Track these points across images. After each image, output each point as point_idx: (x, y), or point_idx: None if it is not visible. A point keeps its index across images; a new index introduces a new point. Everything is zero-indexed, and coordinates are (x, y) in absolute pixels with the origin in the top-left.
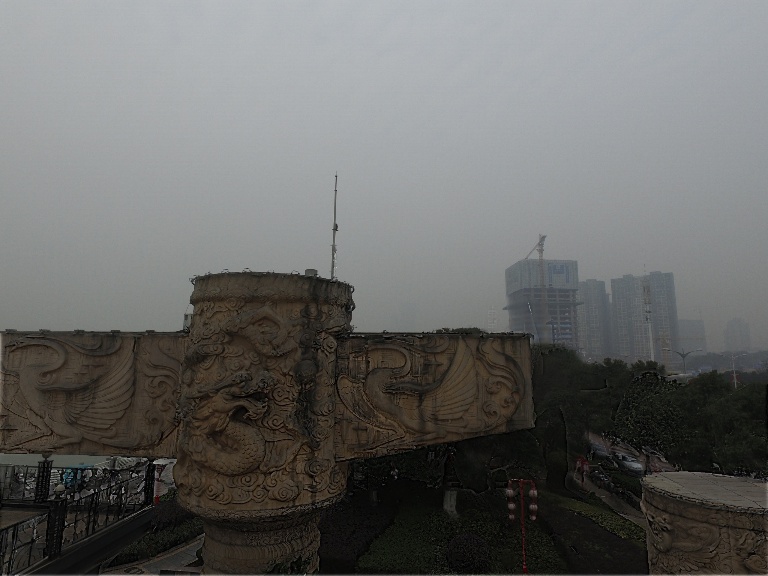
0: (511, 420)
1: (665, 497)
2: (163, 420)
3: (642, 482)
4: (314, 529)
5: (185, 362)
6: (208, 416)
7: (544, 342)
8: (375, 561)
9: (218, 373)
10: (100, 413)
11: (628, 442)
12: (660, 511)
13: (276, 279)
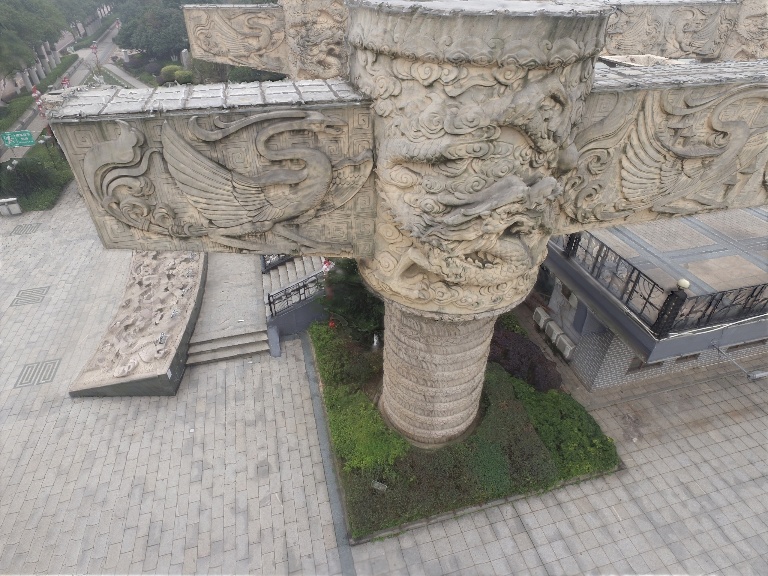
0: None
1: None
2: None
3: None
4: None
5: None
6: None
7: None
8: None
9: None
10: None
11: None
12: None
13: None
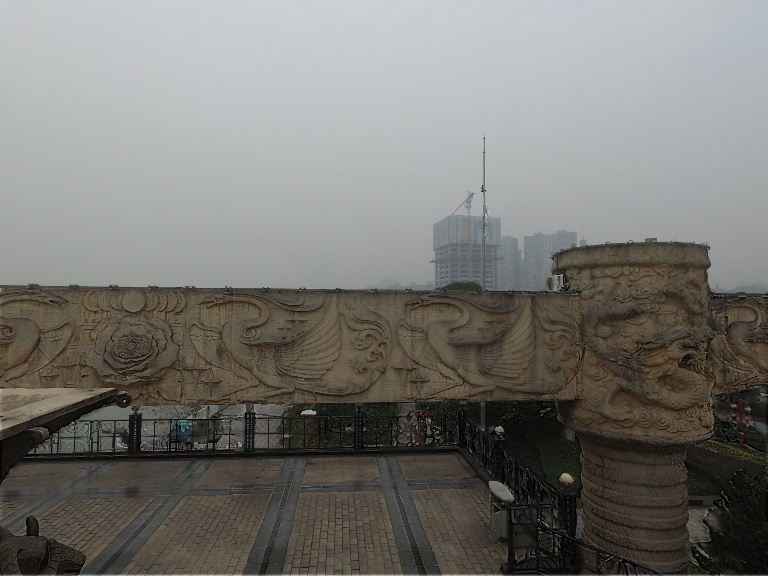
0: None
1: None
2: (564, 368)
3: None
4: None
5: (598, 318)
6: (663, 363)
7: None
8: None
9: (656, 328)
10: (508, 364)
11: None
12: None
13: (693, 248)
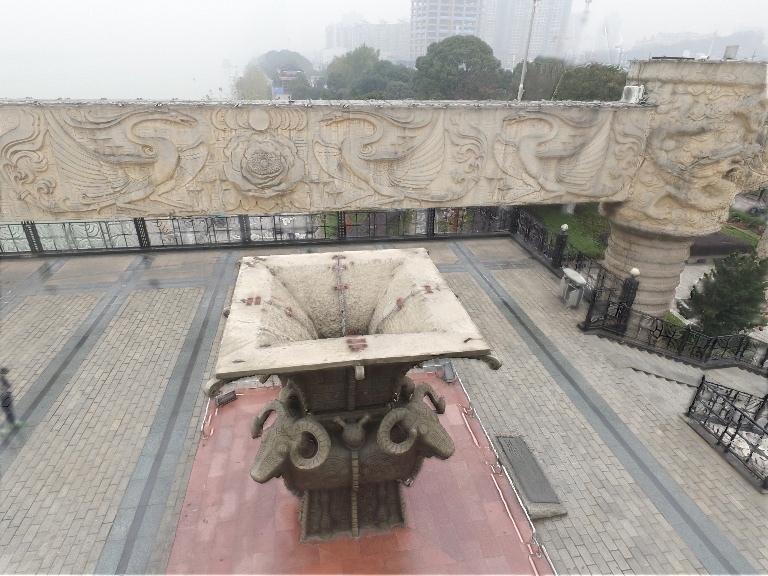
0: None
1: None
2: (623, 176)
3: None
4: None
5: (668, 133)
6: None
7: None
8: (567, 250)
9: (715, 144)
10: (580, 173)
11: None
12: None
13: None
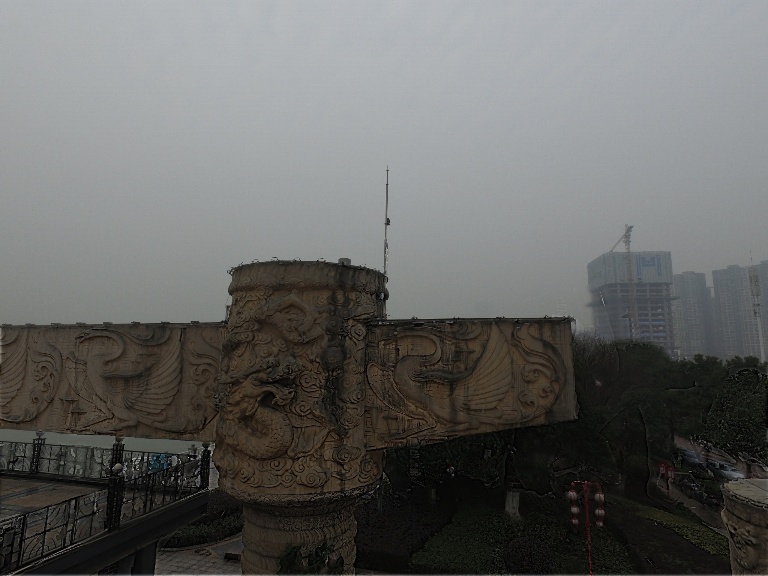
0: (550, 411)
1: (749, 506)
2: (206, 406)
3: (722, 488)
4: (349, 518)
5: (223, 350)
6: (239, 401)
7: (620, 337)
8: (429, 559)
9: (249, 360)
10: (152, 399)
11: (721, 447)
12: (743, 522)
13: (302, 267)
